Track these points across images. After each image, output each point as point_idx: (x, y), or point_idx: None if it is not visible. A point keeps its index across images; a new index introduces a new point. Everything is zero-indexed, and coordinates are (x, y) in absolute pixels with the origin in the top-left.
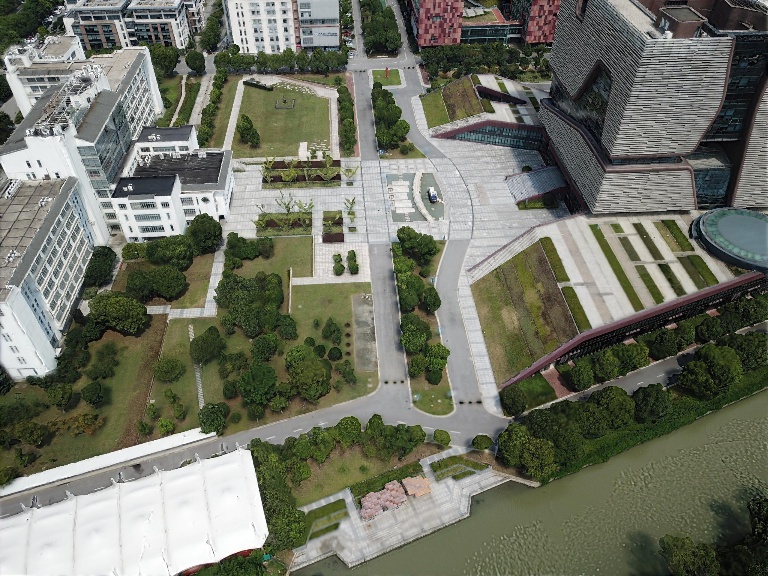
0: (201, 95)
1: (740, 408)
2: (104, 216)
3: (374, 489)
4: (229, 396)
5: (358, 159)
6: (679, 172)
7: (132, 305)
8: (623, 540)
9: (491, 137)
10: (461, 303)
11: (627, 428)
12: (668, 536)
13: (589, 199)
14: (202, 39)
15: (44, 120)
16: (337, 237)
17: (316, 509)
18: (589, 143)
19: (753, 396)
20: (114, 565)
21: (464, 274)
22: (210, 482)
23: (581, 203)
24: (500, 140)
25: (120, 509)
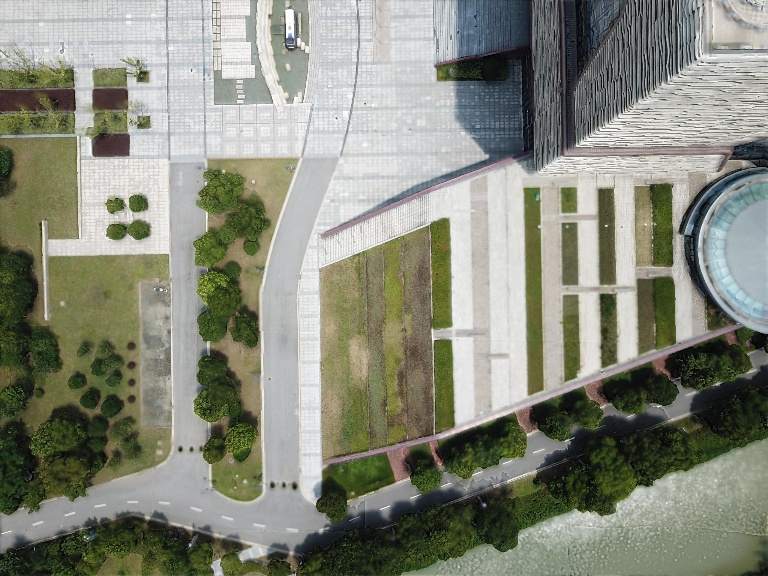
0: None
1: None
2: None
3: None
4: None
5: None
6: (704, 155)
7: None
8: None
9: None
10: (300, 307)
11: None
12: None
13: (537, 146)
14: None
15: None
16: (116, 147)
17: None
18: (562, 53)
19: None
20: None
21: (314, 244)
22: None
23: None
24: None
25: None
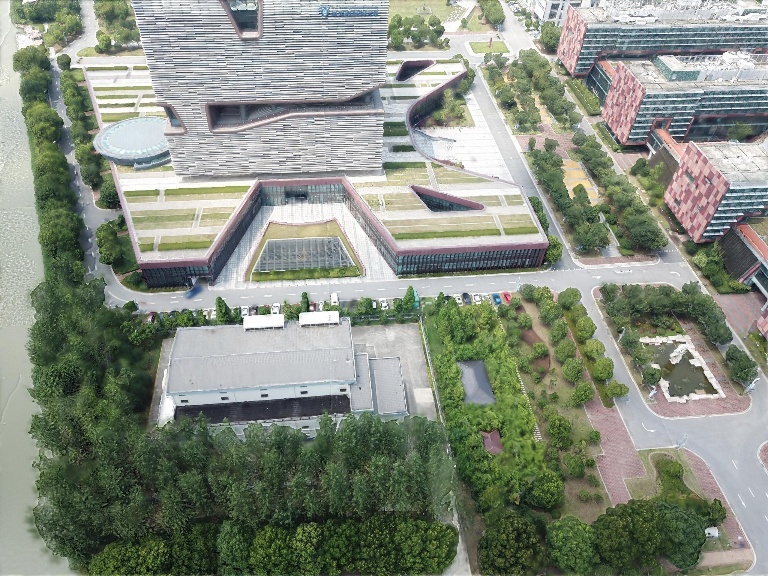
0: None
1: None
2: None
3: None
4: None
5: None
6: None
7: None
8: None
9: None
10: None
11: None
12: None
13: None
14: None
15: None
16: None
17: None
18: None
19: None
20: None
21: None
22: None
23: None
24: None
25: None
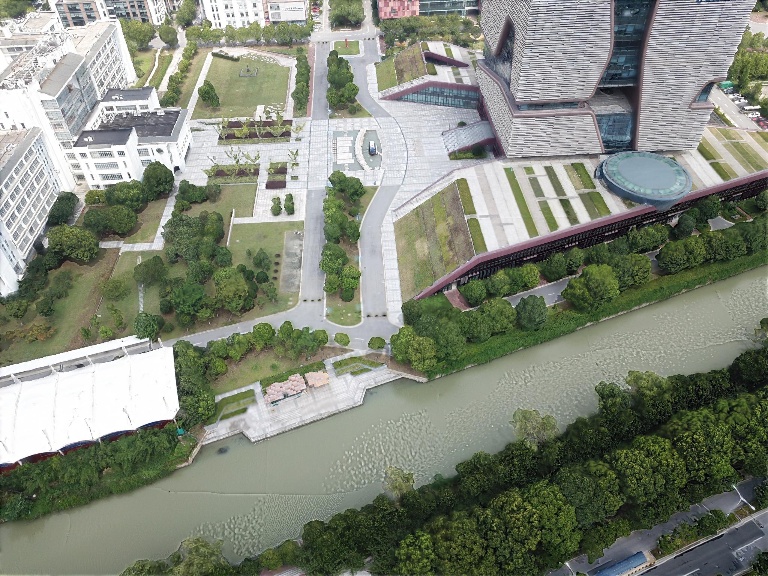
0: (172, 66)
1: (622, 323)
2: (70, 166)
3: (280, 382)
4: (164, 310)
5: (309, 119)
6: (581, 117)
7: (84, 236)
8: (493, 422)
9: (434, 98)
10: (383, 237)
11: (511, 335)
12: (519, 409)
13: (505, 145)
14: (177, 16)
15: (11, 77)
16: (279, 184)
17: (228, 397)
18: (504, 93)
19: (633, 311)
20: (47, 430)
21: (390, 214)
22: (135, 370)
23: (501, 150)
24: (442, 100)
25: (57, 390)
